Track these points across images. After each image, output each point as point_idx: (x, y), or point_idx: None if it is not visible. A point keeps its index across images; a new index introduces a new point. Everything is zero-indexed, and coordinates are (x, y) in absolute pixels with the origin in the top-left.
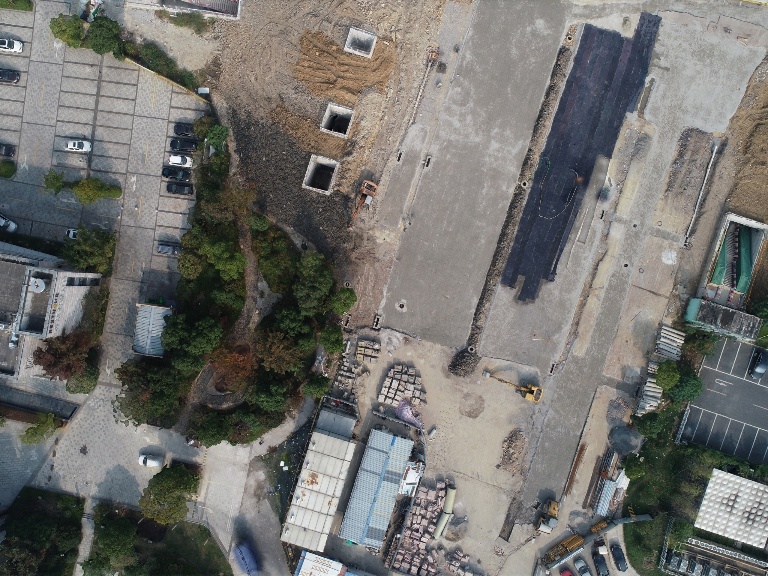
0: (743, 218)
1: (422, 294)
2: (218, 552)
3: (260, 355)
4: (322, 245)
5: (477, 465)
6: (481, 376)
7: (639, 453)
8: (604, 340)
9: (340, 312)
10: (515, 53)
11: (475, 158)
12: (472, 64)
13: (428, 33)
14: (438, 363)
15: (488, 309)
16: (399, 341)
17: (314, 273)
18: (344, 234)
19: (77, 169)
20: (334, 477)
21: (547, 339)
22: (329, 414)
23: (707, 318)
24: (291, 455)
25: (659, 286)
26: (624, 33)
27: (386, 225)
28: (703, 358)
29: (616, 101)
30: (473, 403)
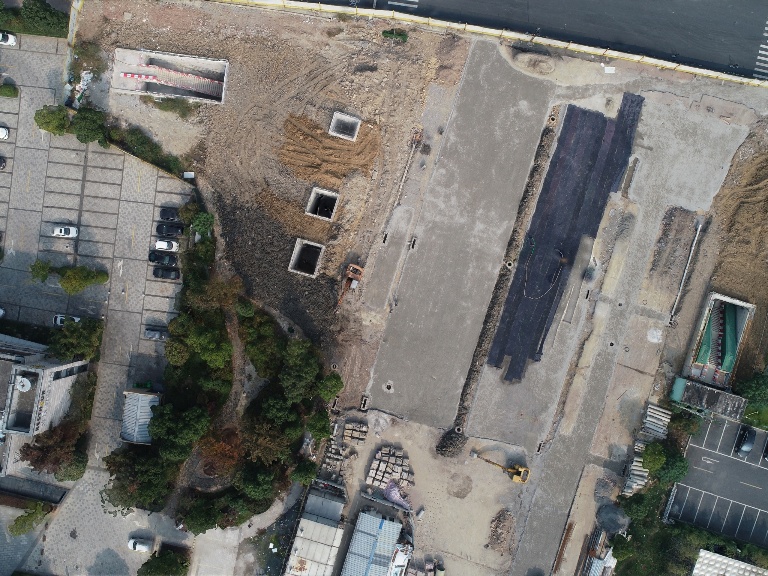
0: (727, 297)
1: (409, 375)
2: None
3: (246, 449)
4: (309, 328)
5: (465, 545)
6: (468, 456)
7: (627, 531)
8: (591, 419)
9: (327, 398)
10: (499, 134)
11: (460, 239)
12: (456, 146)
13: (412, 115)
14: (425, 444)
15: (475, 389)
16: (386, 422)
17: (300, 362)
18: (330, 317)
19: (64, 254)
20: (322, 563)
21: (534, 419)
22: (317, 498)
23: (692, 399)
24: (280, 537)
25: (645, 364)
26: (607, 113)
27: (372, 307)
28: (689, 436)
29: (600, 181)
30: (461, 483)
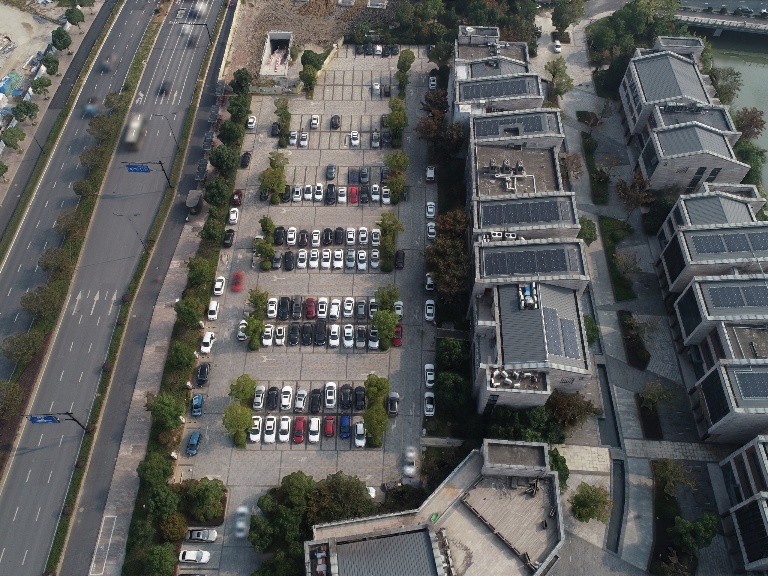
0: None
1: None
2: (596, 22)
3: None
4: (415, 1)
5: None
6: None
7: None
8: None
9: None
10: None
11: None
12: None
13: None
14: None
15: None
16: None
17: None
18: None
19: (391, 90)
20: None
21: None
22: None
23: None
24: None
25: None
26: None
27: None
28: None
29: None
30: None
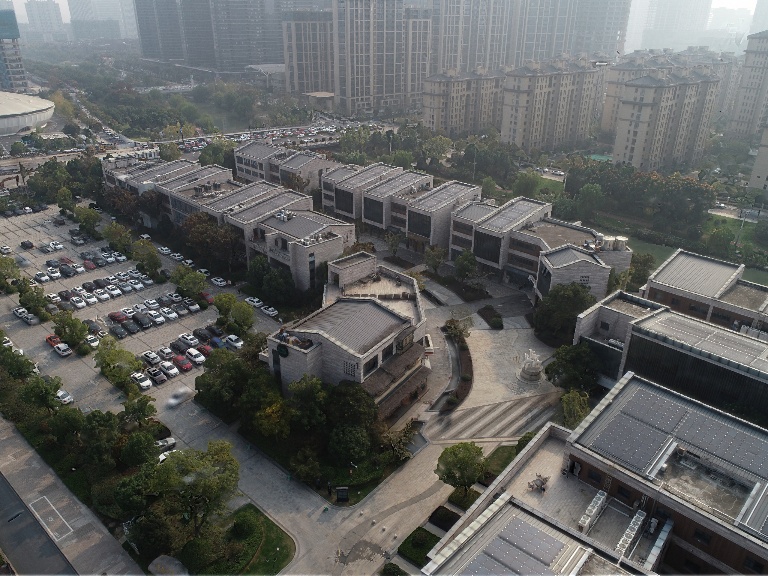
0: None
1: None
2: None
3: None
4: None
5: None
6: None
7: None
8: None
9: None
10: None
11: None
12: None
13: None
14: None
15: None
16: None
17: None
18: None
19: None
20: None
21: None
22: None
23: None
24: None
25: None
26: None
27: None
28: None
29: None
30: None
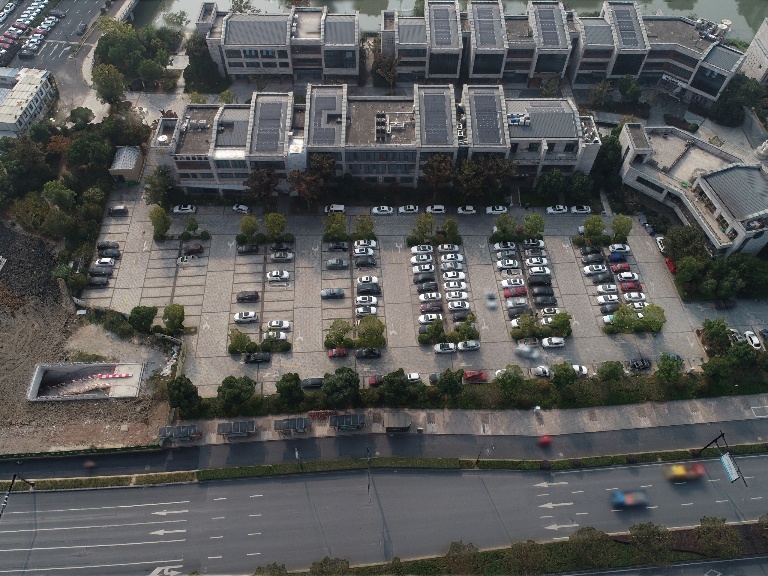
0: None
1: None
2: None
3: None
4: None
5: None
6: None
7: None
8: None
9: None
10: None
11: None
12: None
13: None
14: None
15: None
16: None
17: None
18: None
19: None
20: (6, 106)
21: None
22: None
23: None
24: None
25: None
26: None
27: None
28: None
29: None
30: None
